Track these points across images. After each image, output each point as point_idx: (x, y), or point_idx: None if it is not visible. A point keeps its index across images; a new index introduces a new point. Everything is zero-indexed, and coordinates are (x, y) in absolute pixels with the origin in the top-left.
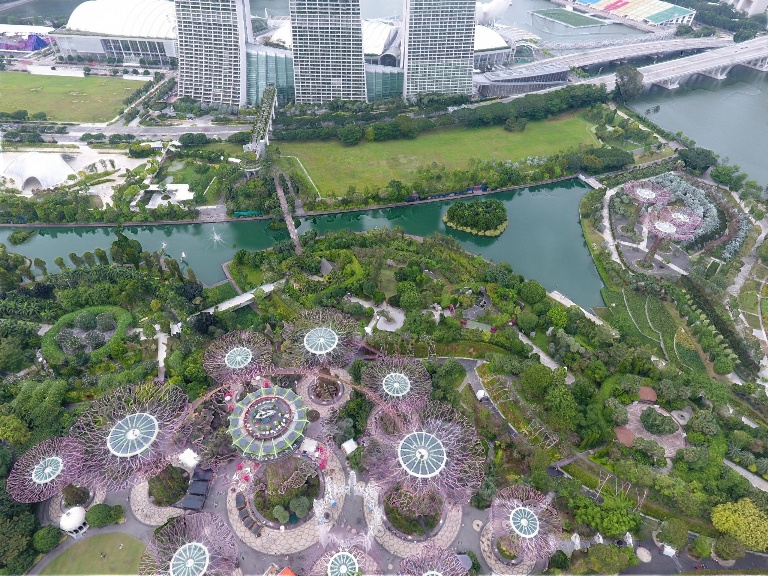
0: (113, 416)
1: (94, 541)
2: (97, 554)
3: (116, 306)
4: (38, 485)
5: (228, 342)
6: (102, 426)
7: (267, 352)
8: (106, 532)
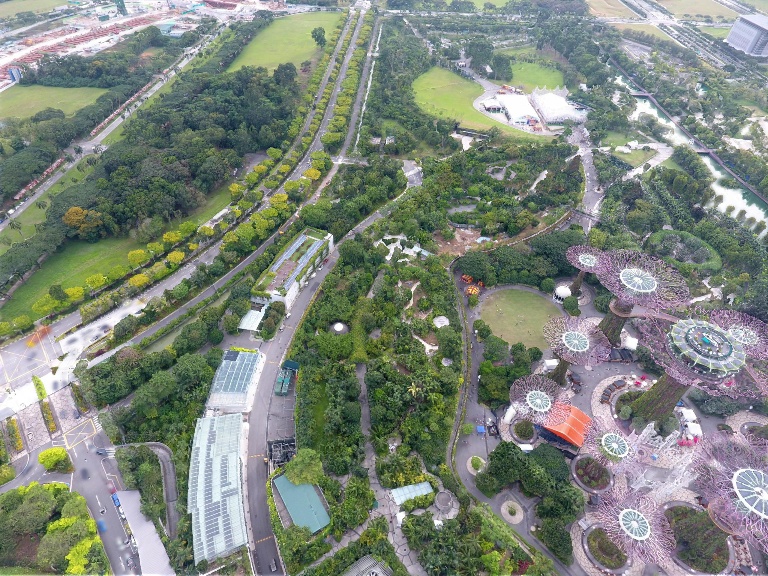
0: (642, 267)
1: (555, 309)
2: (549, 313)
3: (720, 256)
4: (578, 260)
5: (752, 324)
6: (633, 264)
7: (767, 355)
8: (562, 313)
